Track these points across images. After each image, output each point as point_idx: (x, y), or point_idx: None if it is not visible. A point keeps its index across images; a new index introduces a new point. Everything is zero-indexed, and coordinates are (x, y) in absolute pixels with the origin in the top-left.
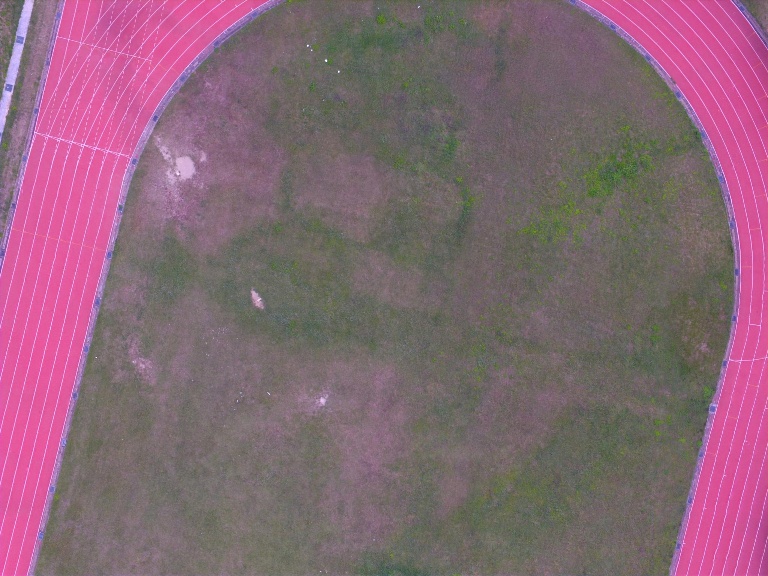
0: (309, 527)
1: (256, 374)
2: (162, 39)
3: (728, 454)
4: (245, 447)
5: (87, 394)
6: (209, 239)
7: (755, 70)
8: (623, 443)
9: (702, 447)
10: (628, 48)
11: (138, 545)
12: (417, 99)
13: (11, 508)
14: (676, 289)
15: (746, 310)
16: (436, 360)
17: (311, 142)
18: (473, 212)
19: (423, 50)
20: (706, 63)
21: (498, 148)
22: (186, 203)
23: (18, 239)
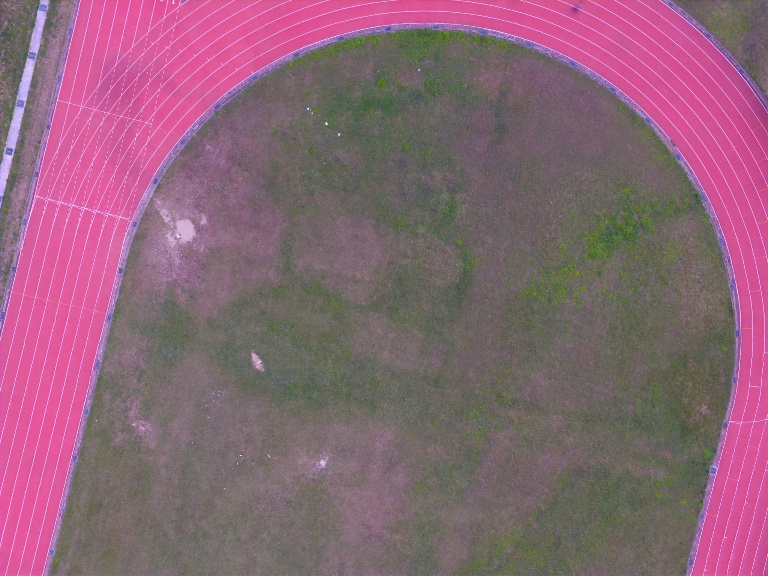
0: None
1: (256, 436)
2: (162, 102)
3: (729, 516)
4: (245, 510)
5: (87, 457)
6: (209, 302)
7: (755, 133)
8: (624, 505)
9: (703, 509)
10: (628, 111)
11: None
12: (417, 162)
13: (11, 571)
14: (676, 351)
15: (746, 372)
16: (436, 422)
17: (311, 205)
18: (473, 274)
19: (423, 113)
20: (706, 126)
21: (498, 210)
22: (186, 266)
23: (18, 302)
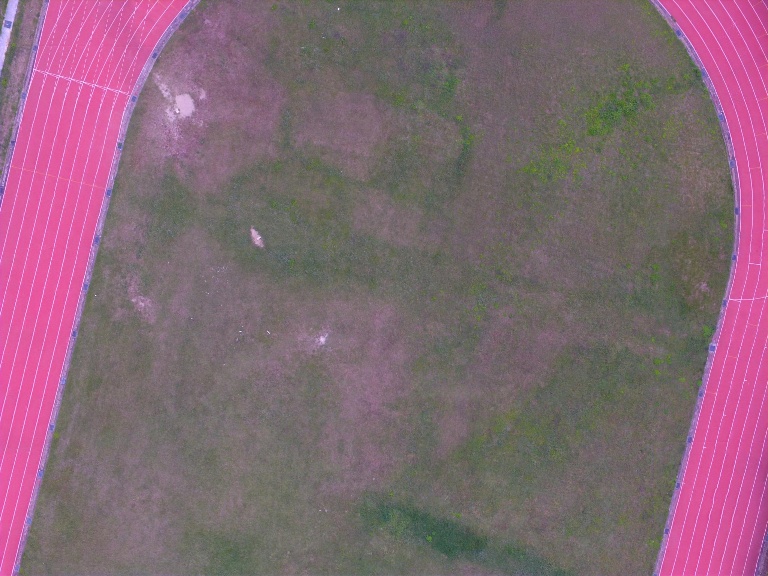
0: (309, 466)
1: (256, 313)
2: None
3: (728, 393)
4: (245, 386)
5: (86, 332)
6: (209, 177)
7: (755, 8)
8: (623, 382)
9: (702, 386)
10: None
11: (138, 484)
12: (417, 37)
13: (11, 446)
14: (676, 228)
15: (746, 249)
16: (436, 299)
17: (311, 80)
18: (473, 150)
19: None
20: (706, 1)
21: (498, 86)
22: (186, 141)
23: (17, 176)
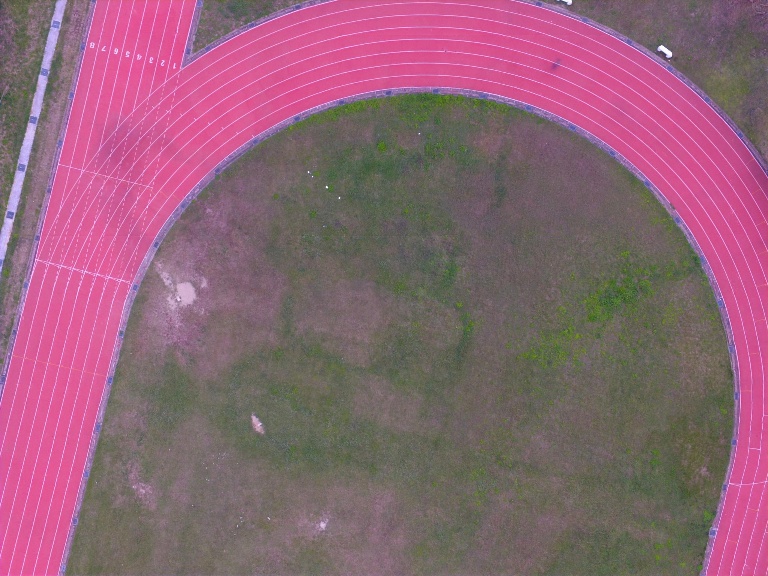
0: None
1: (256, 499)
2: (163, 166)
3: None
4: (245, 572)
5: (87, 519)
6: (210, 364)
7: (754, 196)
8: (623, 567)
9: (702, 571)
10: (627, 174)
11: None
12: (417, 225)
13: None
14: (676, 413)
15: (746, 434)
16: (436, 484)
17: (312, 268)
18: (473, 337)
19: (423, 176)
20: (705, 189)
21: (498, 273)
22: (187, 329)
23: (19, 365)
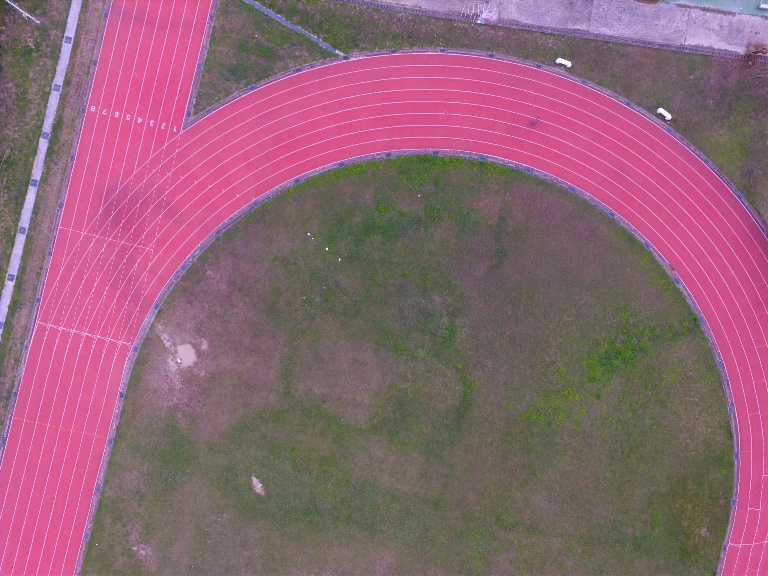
0: None
1: (256, 560)
2: (164, 228)
3: None
4: None
5: None
6: (210, 426)
7: (753, 257)
8: None
9: None
10: (627, 236)
11: None
12: (417, 286)
13: None
14: (676, 474)
15: (745, 494)
16: (436, 545)
17: (312, 329)
18: (473, 398)
19: (423, 238)
20: (705, 250)
21: (498, 334)
22: (187, 390)
23: (19, 428)
